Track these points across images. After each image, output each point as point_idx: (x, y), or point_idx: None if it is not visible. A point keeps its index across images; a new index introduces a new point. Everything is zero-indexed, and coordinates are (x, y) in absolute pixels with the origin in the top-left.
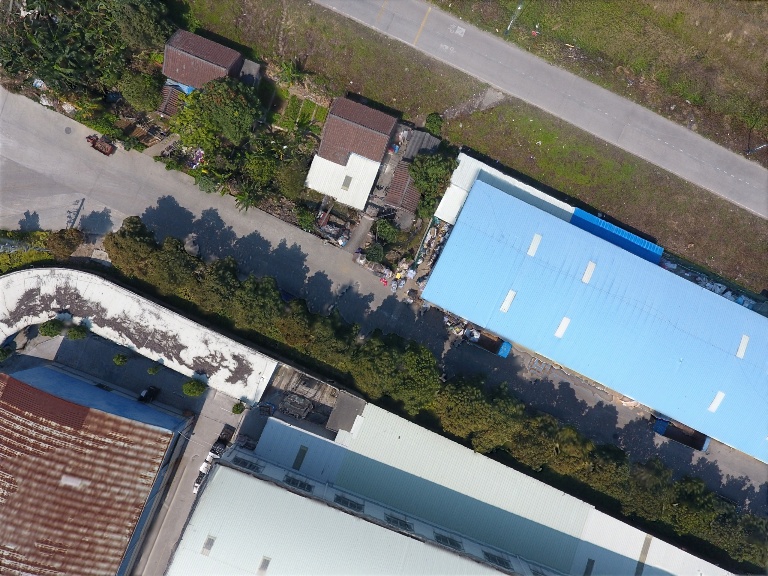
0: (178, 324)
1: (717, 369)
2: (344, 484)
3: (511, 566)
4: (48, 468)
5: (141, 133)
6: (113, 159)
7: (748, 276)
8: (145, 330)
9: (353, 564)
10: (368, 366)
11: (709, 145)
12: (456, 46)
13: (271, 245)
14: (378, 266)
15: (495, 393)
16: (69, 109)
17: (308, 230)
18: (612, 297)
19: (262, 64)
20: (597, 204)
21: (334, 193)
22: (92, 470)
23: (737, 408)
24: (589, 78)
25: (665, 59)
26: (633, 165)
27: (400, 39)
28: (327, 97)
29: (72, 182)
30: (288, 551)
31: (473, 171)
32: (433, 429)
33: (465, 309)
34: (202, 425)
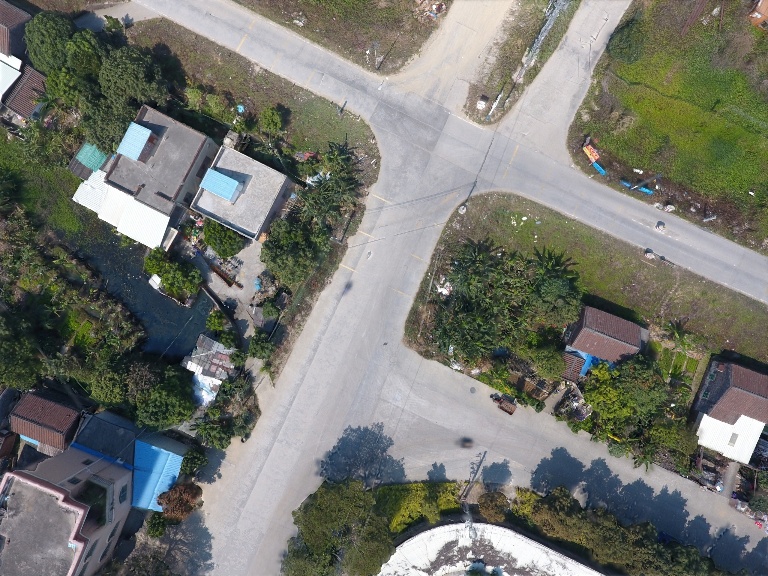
0: (583, 574)
1: None
2: None
3: None
4: None
5: (531, 387)
6: (512, 415)
7: None
8: None
9: None
10: None
11: None
12: None
13: (654, 491)
14: (758, 513)
15: None
16: (476, 372)
17: (686, 476)
18: None
19: (645, 326)
20: None
21: (721, 449)
22: None
23: None
24: None
25: None
26: None
27: None
28: (703, 354)
29: (476, 436)
30: None
31: None
32: None
33: None
34: None
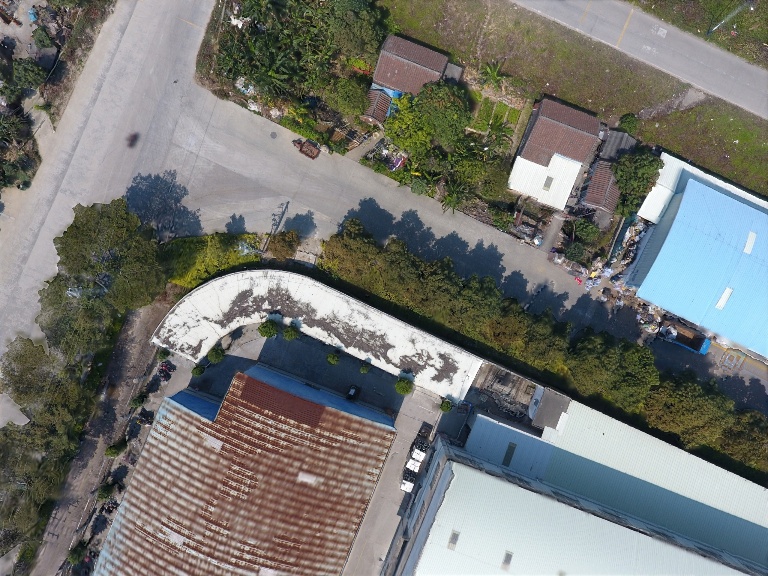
0: (386, 324)
1: None
2: (552, 480)
3: (726, 561)
4: (286, 465)
5: (340, 137)
6: (316, 163)
7: None
8: (353, 330)
9: (590, 558)
10: (595, 363)
11: None
12: (658, 47)
13: (469, 245)
14: (576, 265)
15: (706, 390)
16: (276, 114)
17: (504, 230)
18: None
19: None
20: None
21: (535, 194)
22: (326, 467)
23: None
24: None
25: None
26: None
27: (603, 41)
28: (523, 99)
29: (277, 185)
30: (528, 546)
31: (676, 170)
32: (634, 426)
33: (680, 307)
34: (401, 423)
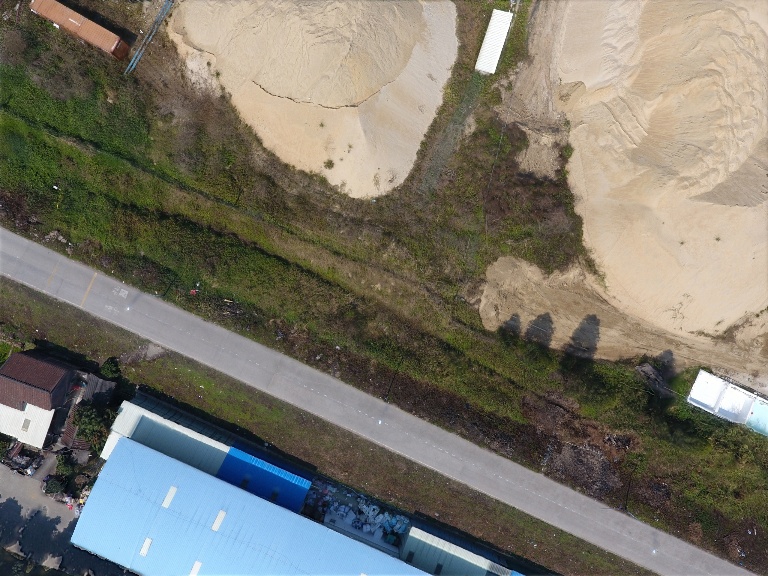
0: None
1: None
2: None
3: None
4: None
5: None
6: None
7: (400, 499)
8: None
9: None
10: None
11: (351, 390)
12: (119, 307)
13: None
14: (59, 495)
15: None
16: None
17: (1, 460)
18: (239, 543)
19: None
20: (262, 436)
21: (15, 434)
22: None
23: None
24: (241, 333)
25: (315, 311)
26: (281, 410)
27: (68, 301)
28: (17, 343)
29: None
30: None
31: (135, 417)
32: None
33: (110, 552)
34: None
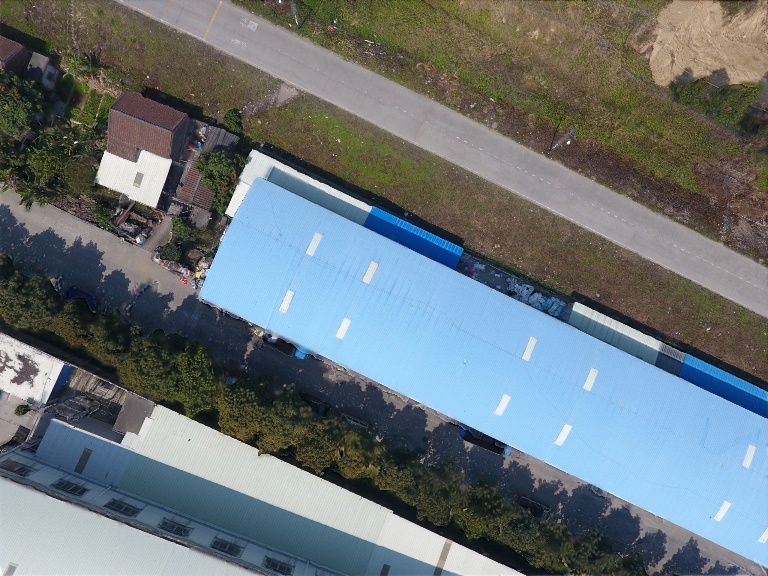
0: None
1: (502, 372)
2: (129, 488)
3: (292, 572)
4: None
5: None
6: None
7: (557, 277)
8: None
9: (107, 570)
10: (132, 367)
11: (509, 144)
12: (248, 41)
13: (66, 243)
14: (174, 265)
15: (279, 395)
16: None
17: (105, 228)
18: (394, 298)
19: (55, 57)
20: (403, 203)
21: (126, 190)
22: None
23: (523, 411)
24: (386, 75)
25: (467, 56)
26: (431, 164)
27: (190, 33)
28: (124, 92)
29: None
30: (37, 557)
31: (265, 168)
32: None
33: (244, 309)
34: None
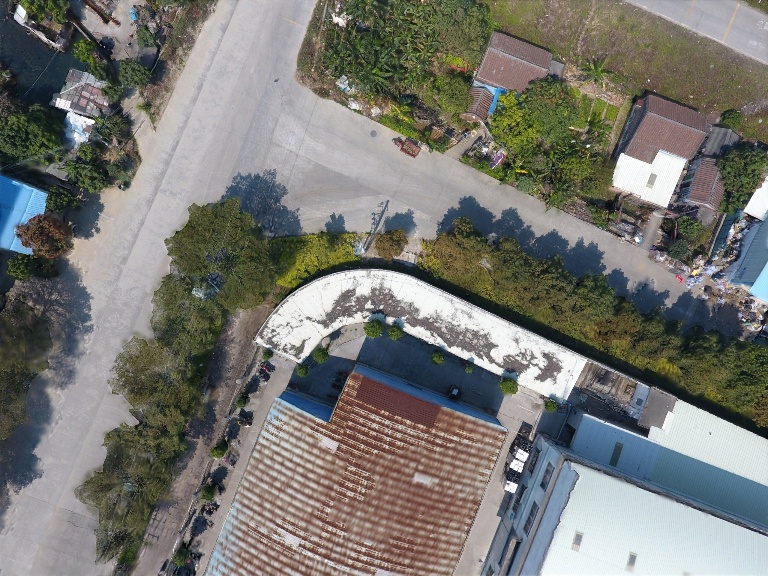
0: (490, 323)
1: None
2: (660, 480)
3: None
4: (403, 466)
5: (439, 135)
6: (416, 161)
7: None
8: (457, 329)
9: (713, 559)
10: (713, 362)
11: None
12: (765, 42)
13: (569, 244)
14: (678, 263)
15: None
16: (376, 112)
17: (604, 228)
18: None
19: None
20: None
21: (639, 191)
22: (440, 468)
23: None
24: None
25: None
26: None
27: (709, 36)
28: (623, 96)
29: (377, 184)
30: (651, 547)
31: None
32: (740, 425)
33: None
34: None
